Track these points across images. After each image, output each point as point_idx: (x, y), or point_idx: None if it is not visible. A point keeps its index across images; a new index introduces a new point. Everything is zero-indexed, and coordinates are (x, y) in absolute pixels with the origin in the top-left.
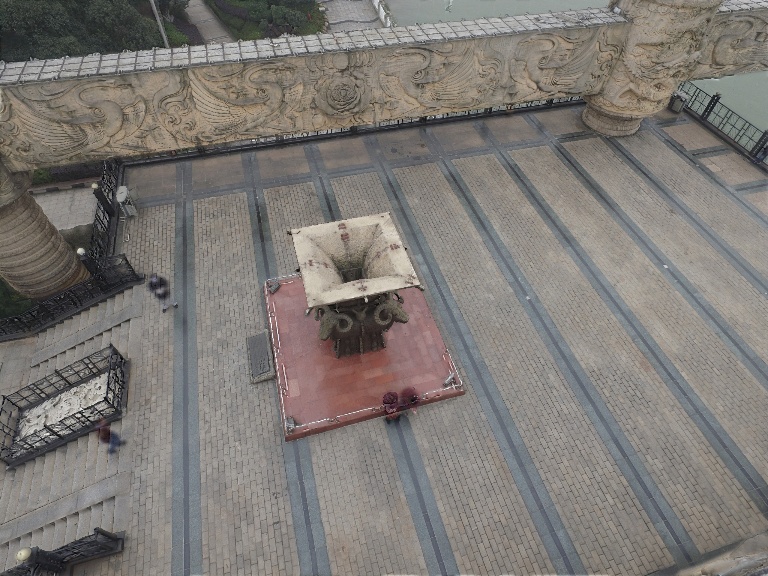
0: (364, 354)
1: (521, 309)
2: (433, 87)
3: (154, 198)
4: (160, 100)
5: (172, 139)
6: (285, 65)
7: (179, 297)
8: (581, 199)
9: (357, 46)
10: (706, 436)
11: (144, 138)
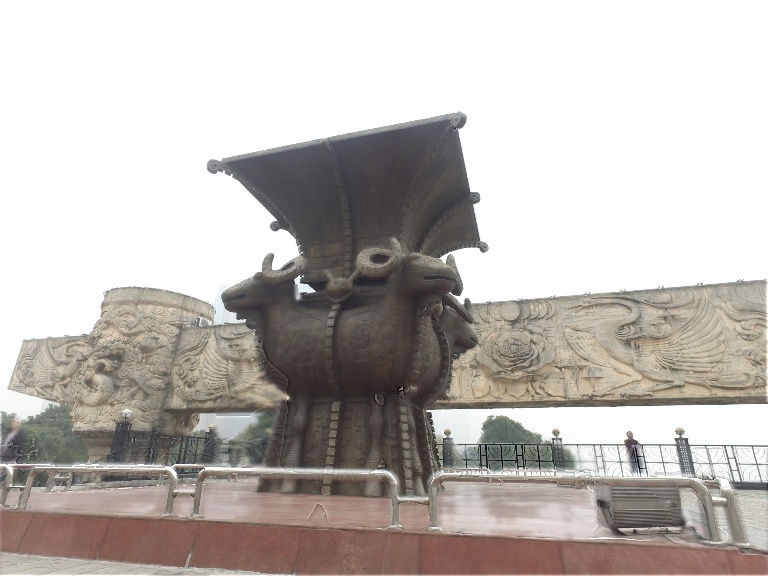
0: (332, 494)
1: None
2: (657, 350)
3: None
4: None
5: None
6: None
7: None
8: None
9: None
10: None
11: None
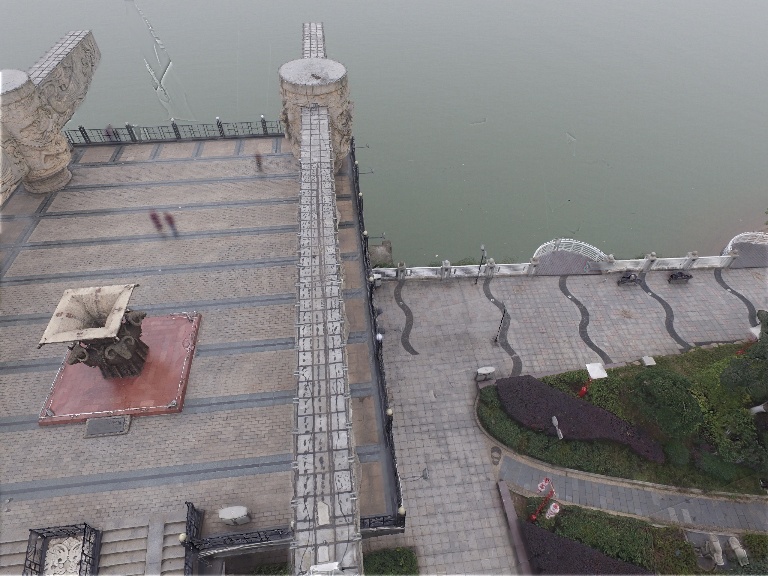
0: (146, 360)
1: (165, 276)
2: None
3: None
4: None
5: None
6: None
7: (0, 498)
8: (106, 221)
9: None
10: (269, 233)
11: None
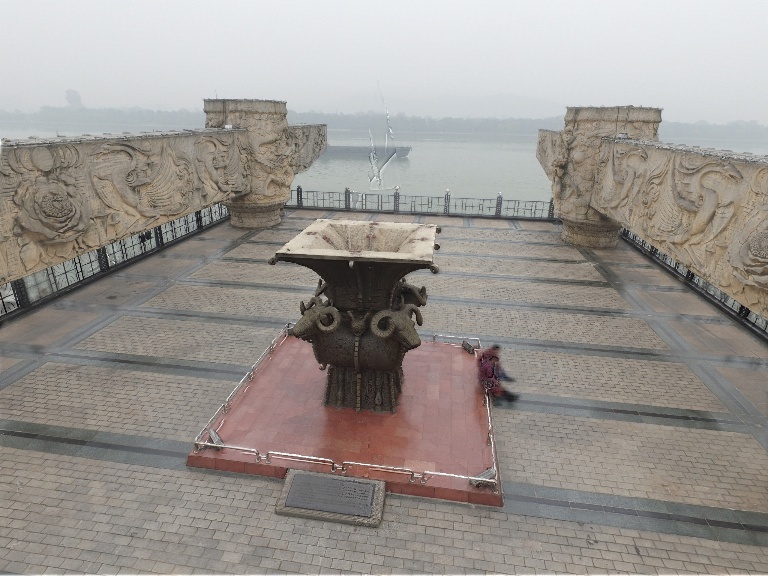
0: (402, 391)
1: None
2: (146, 192)
3: None
4: None
5: None
6: None
7: None
8: None
9: (54, 141)
10: (549, 283)
11: None
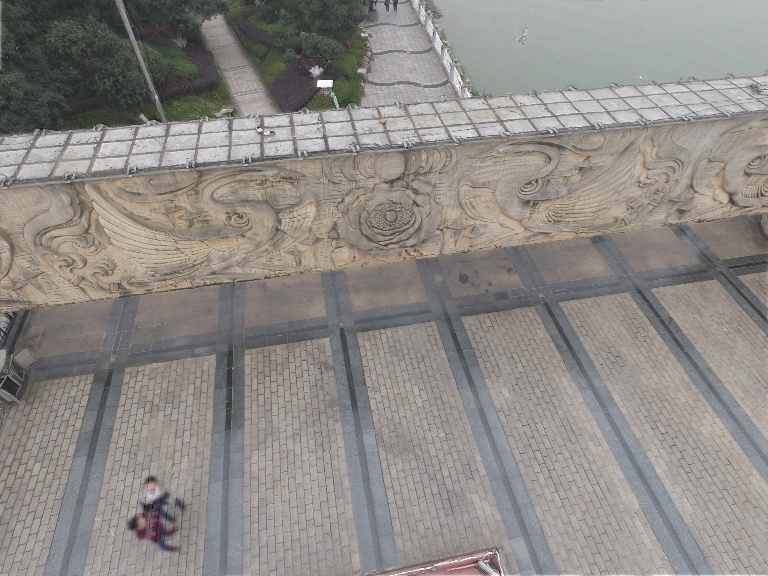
0: None
1: None
2: (553, 203)
3: (64, 359)
4: (37, 234)
5: (75, 288)
6: (281, 174)
7: None
8: None
9: (424, 139)
10: None
11: (20, 289)
